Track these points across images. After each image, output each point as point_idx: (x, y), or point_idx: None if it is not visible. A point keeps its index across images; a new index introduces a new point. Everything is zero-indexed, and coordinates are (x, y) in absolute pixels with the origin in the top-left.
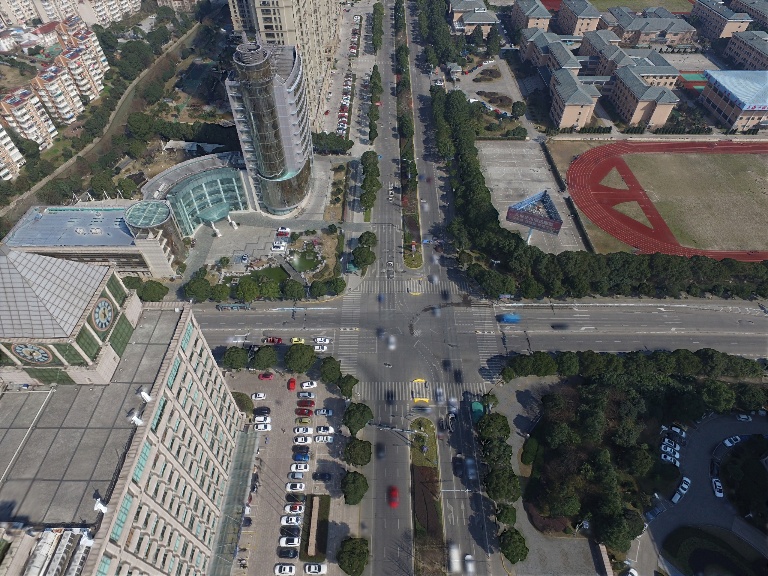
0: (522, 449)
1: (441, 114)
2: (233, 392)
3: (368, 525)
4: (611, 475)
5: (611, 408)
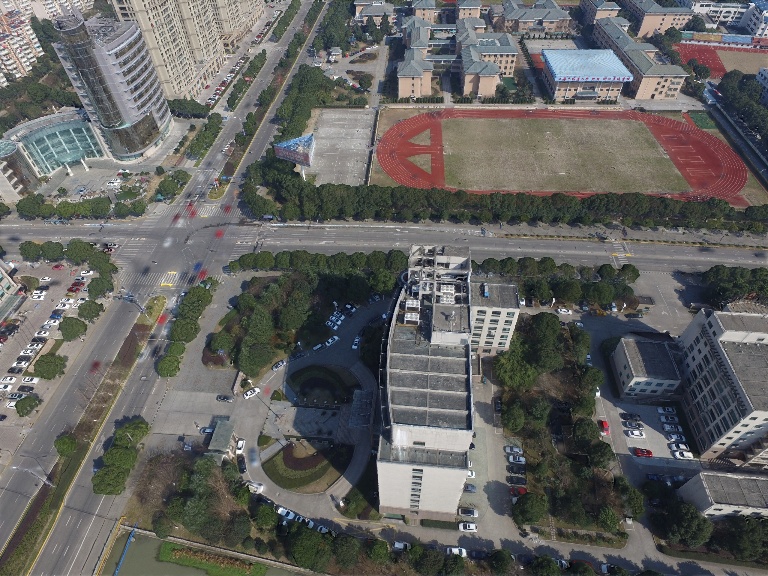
0: (224, 316)
1: (297, 86)
2: (27, 276)
3: (83, 358)
4: (253, 321)
5: (288, 284)
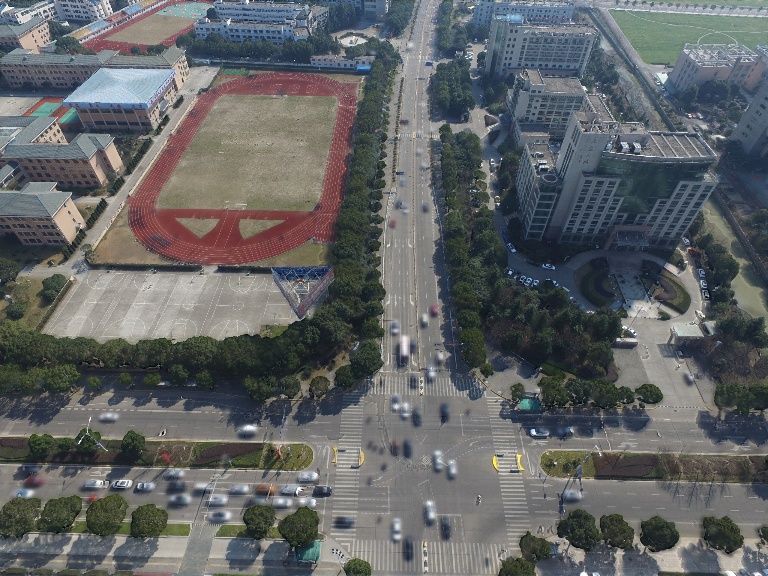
0: None
1: None
2: None
3: None
4: (586, 313)
5: None
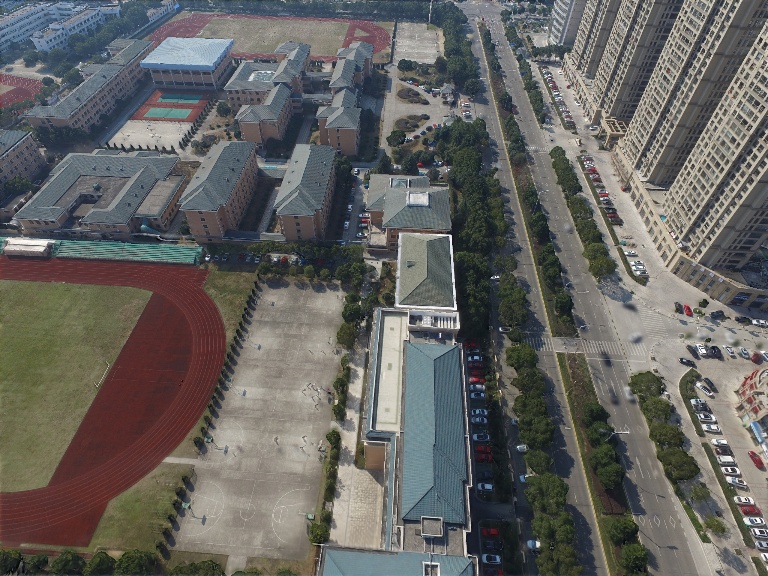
0: None
1: None
2: (538, 4)
3: None
4: None
5: None
